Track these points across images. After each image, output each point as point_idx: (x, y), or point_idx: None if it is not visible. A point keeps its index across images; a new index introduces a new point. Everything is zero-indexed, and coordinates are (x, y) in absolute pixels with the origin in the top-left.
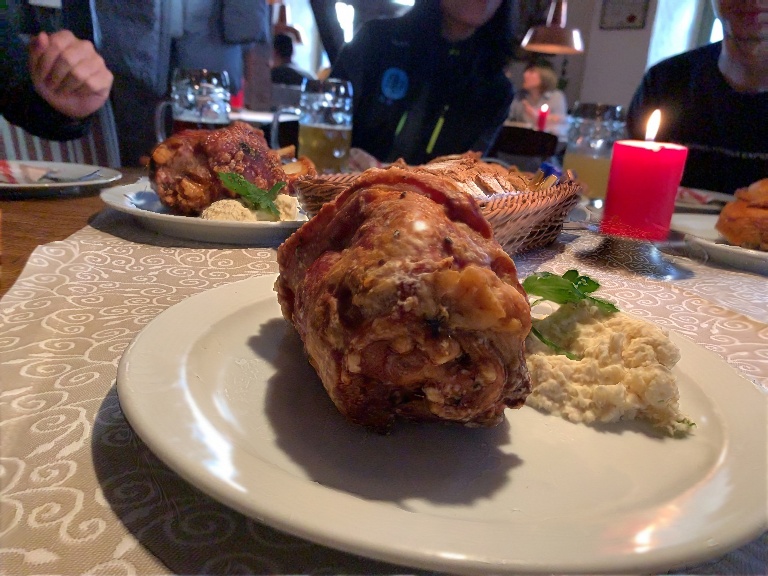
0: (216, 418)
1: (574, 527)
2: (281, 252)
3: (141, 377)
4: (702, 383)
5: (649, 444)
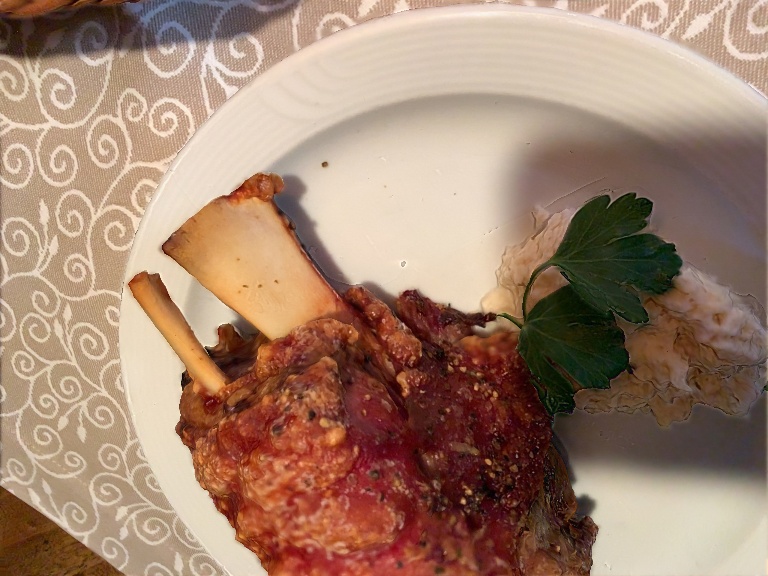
0: None
1: None
2: None
3: None
4: None
5: None
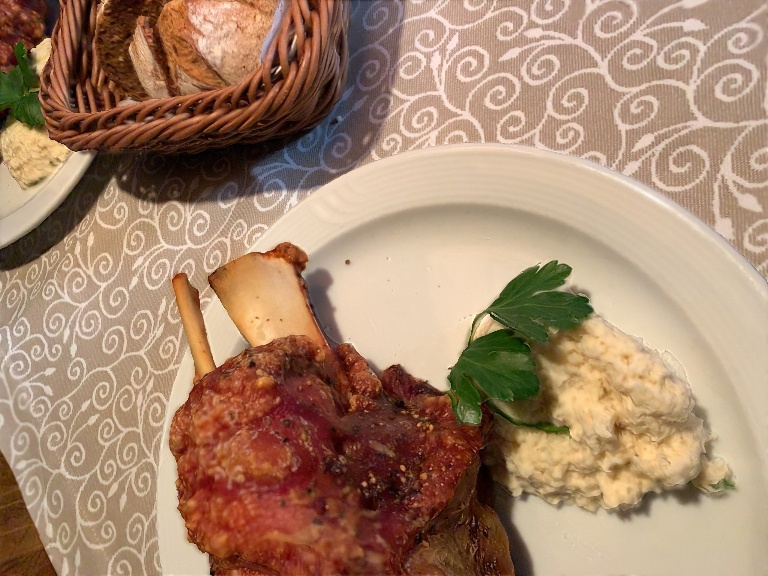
0: None
1: None
2: None
3: None
4: (733, 358)
5: (683, 517)
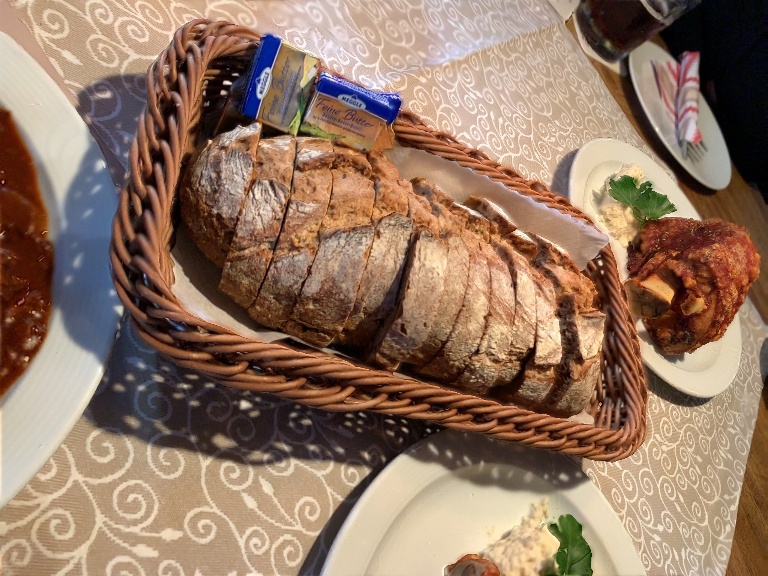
0: None
1: None
2: None
3: (736, 356)
4: None
5: None
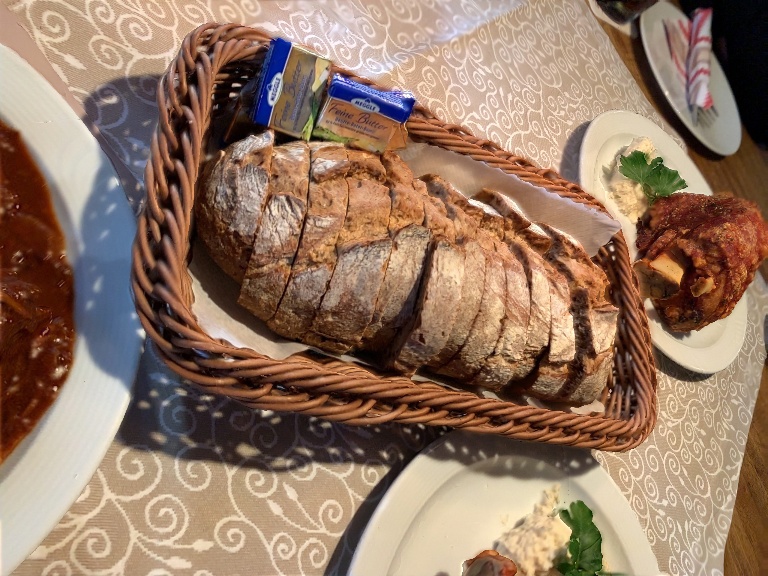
0: None
1: None
2: None
3: (742, 329)
4: None
5: None
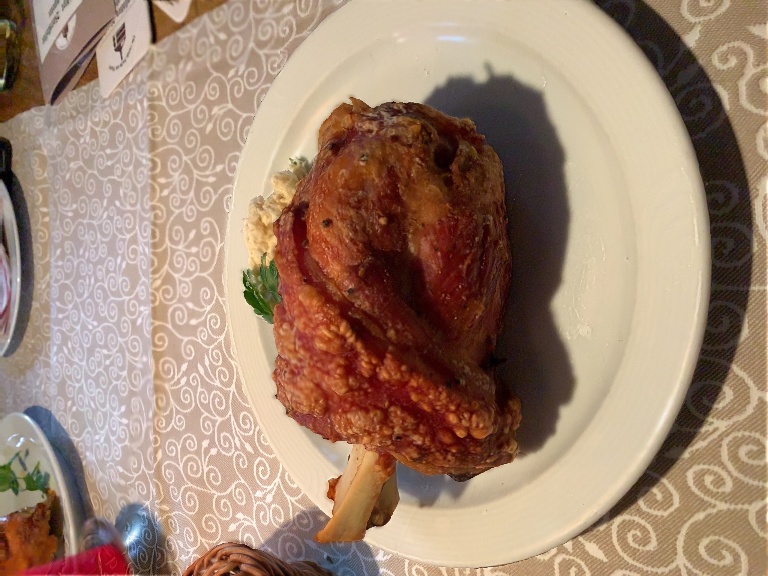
0: (606, 151)
1: (405, 16)
2: (481, 410)
3: (679, 211)
4: None
5: None
